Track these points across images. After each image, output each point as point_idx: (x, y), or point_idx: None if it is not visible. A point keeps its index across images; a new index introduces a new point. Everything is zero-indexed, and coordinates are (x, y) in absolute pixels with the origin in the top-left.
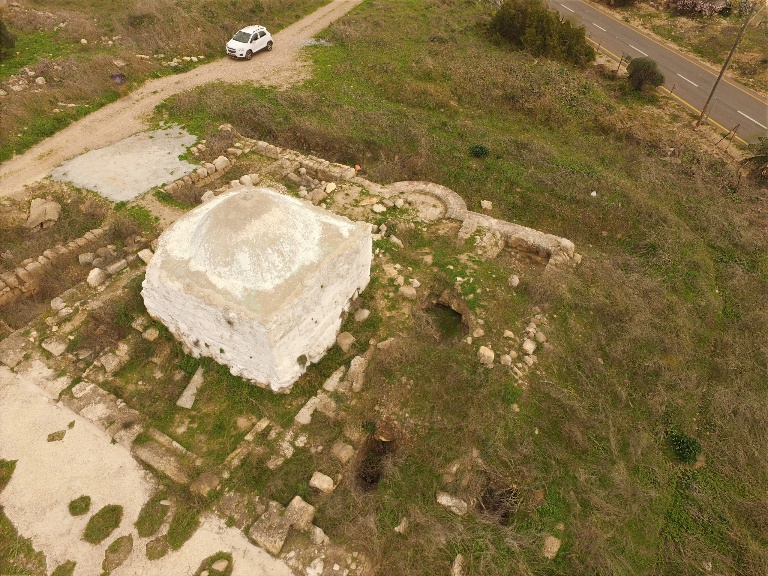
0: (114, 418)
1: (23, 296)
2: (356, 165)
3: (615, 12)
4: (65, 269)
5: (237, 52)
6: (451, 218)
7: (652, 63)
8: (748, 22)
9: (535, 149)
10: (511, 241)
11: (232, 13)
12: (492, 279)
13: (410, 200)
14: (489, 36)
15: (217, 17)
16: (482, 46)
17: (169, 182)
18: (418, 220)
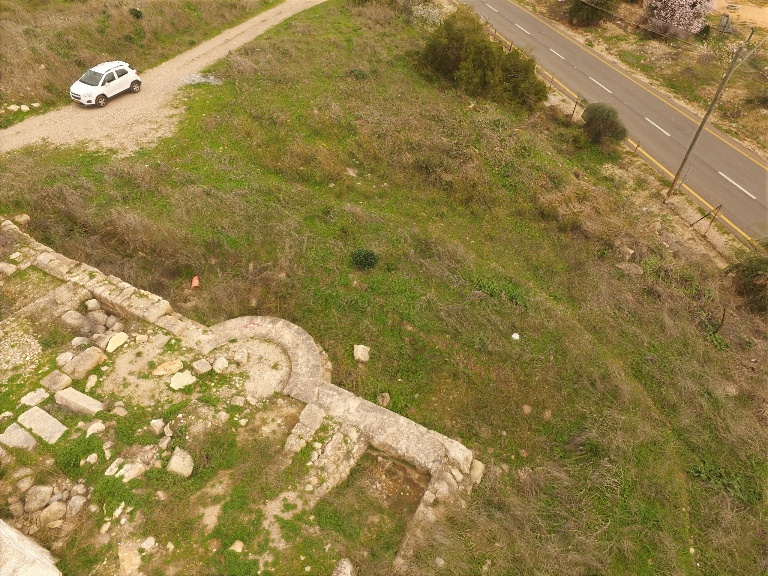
0: None
1: None
2: (194, 278)
3: (577, 33)
4: None
5: (82, 98)
6: (291, 396)
7: (612, 111)
8: (731, 72)
9: (442, 255)
10: (375, 443)
11: (98, 42)
12: (303, 575)
13: (237, 359)
14: (420, 69)
15: (75, 48)
16: (410, 82)
17: None
18: (237, 403)
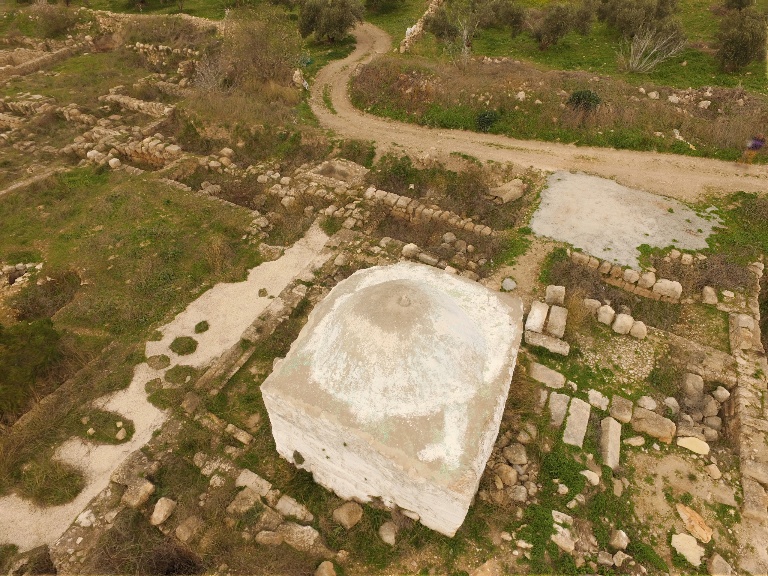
0: (268, 319)
1: (404, 222)
2: None
3: None
4: (437, 231)
5: None
6: None
7: None
8: None
9: None
10: None
11: None
12: None
13: None
14: None
15: None
16: None
17: (587, 252)
18: None
